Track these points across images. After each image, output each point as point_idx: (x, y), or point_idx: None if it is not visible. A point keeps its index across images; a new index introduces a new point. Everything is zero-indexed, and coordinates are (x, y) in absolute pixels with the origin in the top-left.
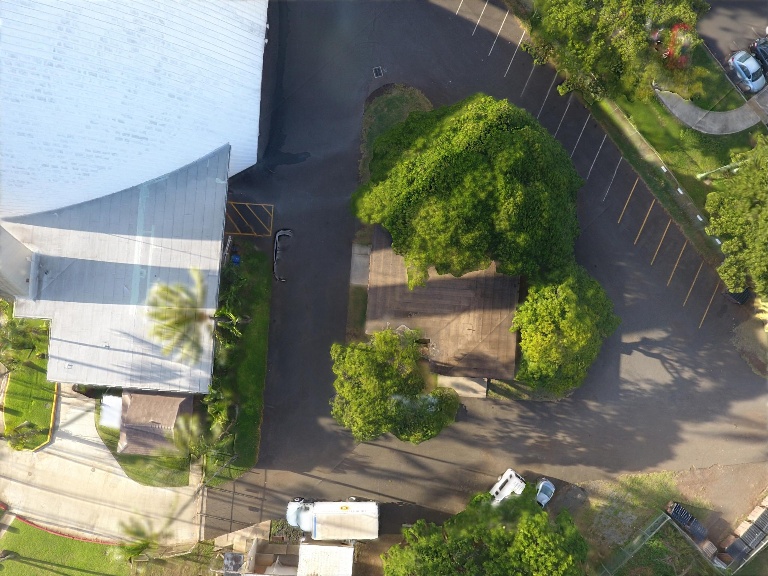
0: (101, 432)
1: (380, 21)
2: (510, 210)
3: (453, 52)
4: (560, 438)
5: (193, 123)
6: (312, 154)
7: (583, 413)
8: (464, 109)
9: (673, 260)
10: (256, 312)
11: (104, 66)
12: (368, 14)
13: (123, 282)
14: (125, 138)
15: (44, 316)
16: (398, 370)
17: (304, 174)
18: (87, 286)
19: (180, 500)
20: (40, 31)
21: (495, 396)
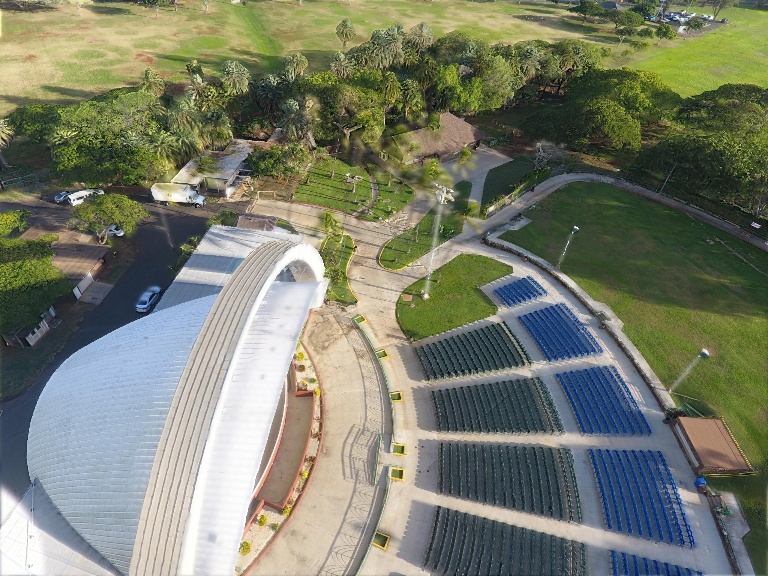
0: None
1: None
2: None
3: None
4: (36, 216)
5: None
6: None
7: None
8: None
9: None
10: None
11: None
12: None
13: None
14: None
15: None
16: None
17: None
18: None
19: (263, 212)
20: None
21: None
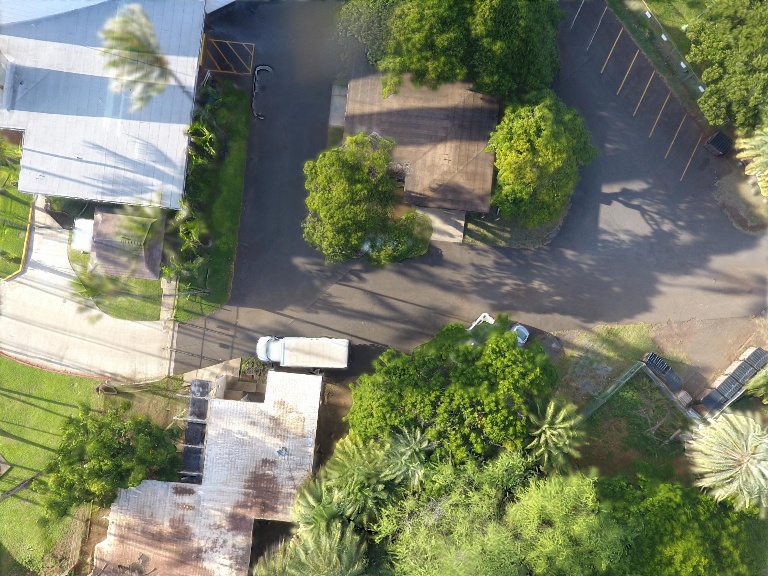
0: (73, 263)
1: None
2: (486, 13)
3: None
4: (536, 286)
5: None
6: None
7: (560, 262)
8: None
9: (656, 112)
10: (233, 149)
11: None
12: None
13: (98, 95)
14: None
15: (17, 126)
16: (369, 175)
17: (286, 15)
18: (61, 98)
19: (150, 334)
20: None
21: (472, 241)
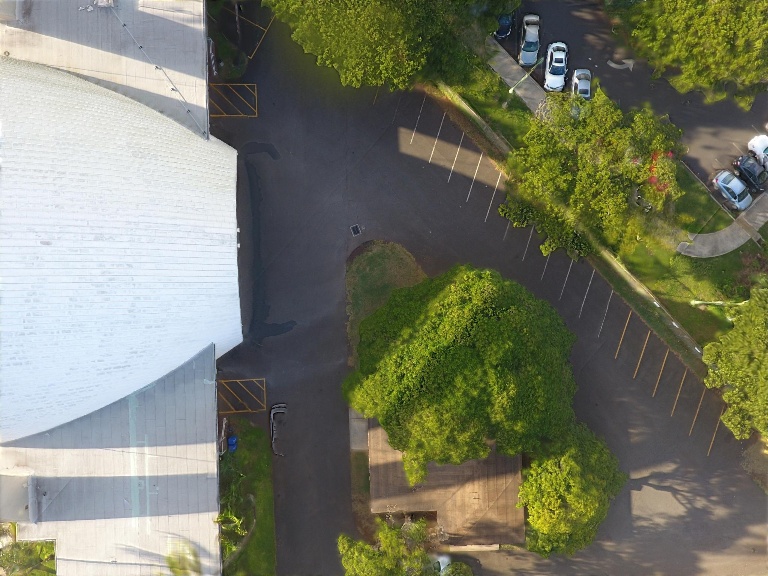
0: None
1: (352, 178)
2: (504, 403)
3: (430, 202)
4: None
5: (174, 341)
6: (298, 322)
7: (598, 554)
8: (447, 290)
9: (675, 390)
10: (259, 489)
11: (77, 322)
12: (339, 172)
13: (122, 495)
14: (107, 371)
15: (47, 537)
16: (408, 572)
17: (292, 343)
18: (87, 503)
19: None
20: (7, 308)
21: (508, 547)
